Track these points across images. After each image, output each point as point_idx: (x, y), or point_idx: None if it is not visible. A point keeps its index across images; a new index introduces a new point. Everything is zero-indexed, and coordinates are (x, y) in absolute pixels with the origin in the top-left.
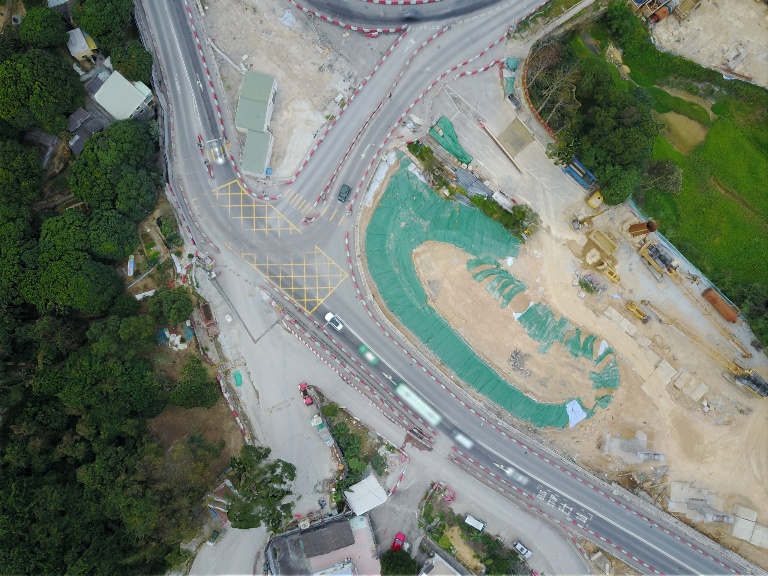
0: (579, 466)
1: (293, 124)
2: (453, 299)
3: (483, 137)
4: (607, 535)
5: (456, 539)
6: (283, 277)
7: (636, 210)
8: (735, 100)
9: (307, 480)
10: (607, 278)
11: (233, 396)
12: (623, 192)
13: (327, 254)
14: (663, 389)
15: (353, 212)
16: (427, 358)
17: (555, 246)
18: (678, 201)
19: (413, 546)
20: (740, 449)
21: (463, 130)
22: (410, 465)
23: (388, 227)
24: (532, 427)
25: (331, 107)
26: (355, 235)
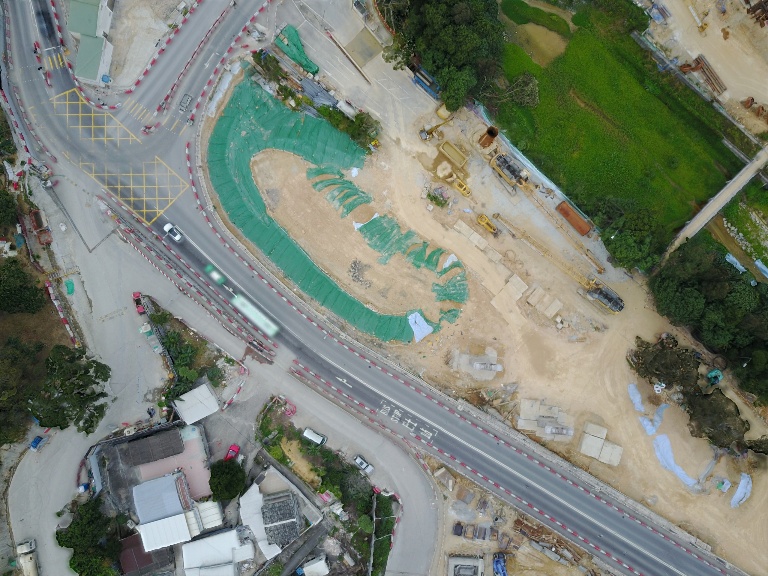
0: (424, 381)
1: (133, 32)
2: (292, 208)
3: (330, 47)
4: (452, 451)
5: (294, 452)
6: (122, 187)
7: (488, 121)
8: (595, 10)
9: (137, 389)
10: (458, 191)
11: (65, 304)
12: (457, 94)
13: (167, 164)
14: (514, 304)
15: (195, 122)
16: (269, 270)
17: (405, 158)
18: (535, 114)
19: (249, 458)
20: (594, 367)
21: (310, 39)
22: (250, 378)
23: (228, 136)
24: (377, 342)
25: (173, 15)
26: (196, 145)
